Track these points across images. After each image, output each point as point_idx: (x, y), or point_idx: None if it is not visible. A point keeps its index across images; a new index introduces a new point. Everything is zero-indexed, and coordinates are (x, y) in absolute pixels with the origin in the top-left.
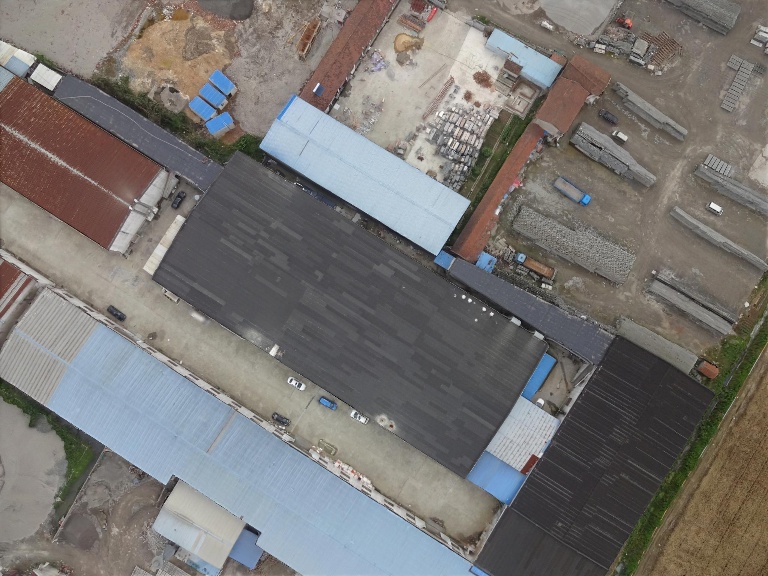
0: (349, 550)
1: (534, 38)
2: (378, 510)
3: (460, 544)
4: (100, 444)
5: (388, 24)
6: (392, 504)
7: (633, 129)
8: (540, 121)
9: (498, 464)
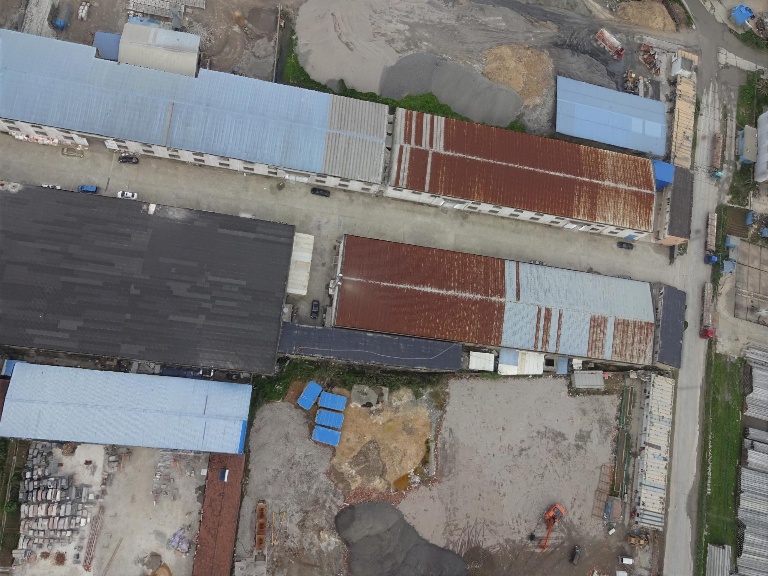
0: (1, 67)
1: None
2: None
3: None
4: None
5: None
6: None
7: None
8: None
9: None
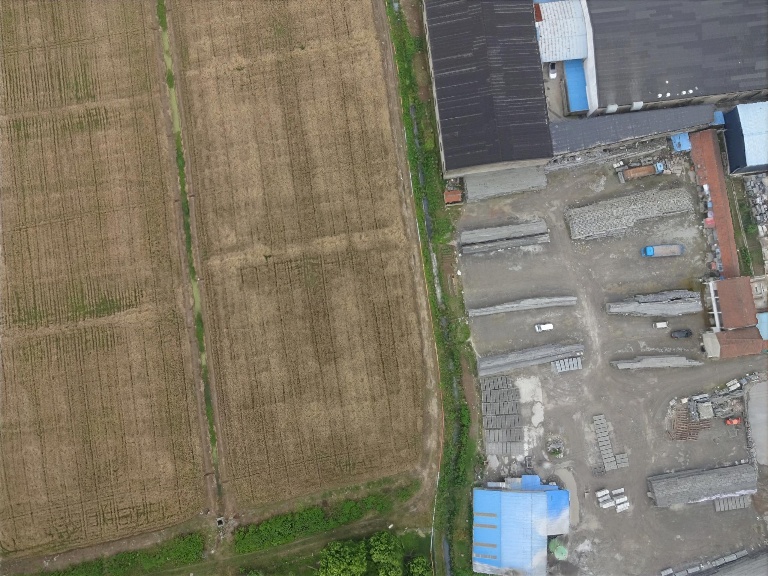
0: None
1: None
2: None
3: None
4: None
5: None
6: None
7: (655, 341)
8: None
9: None
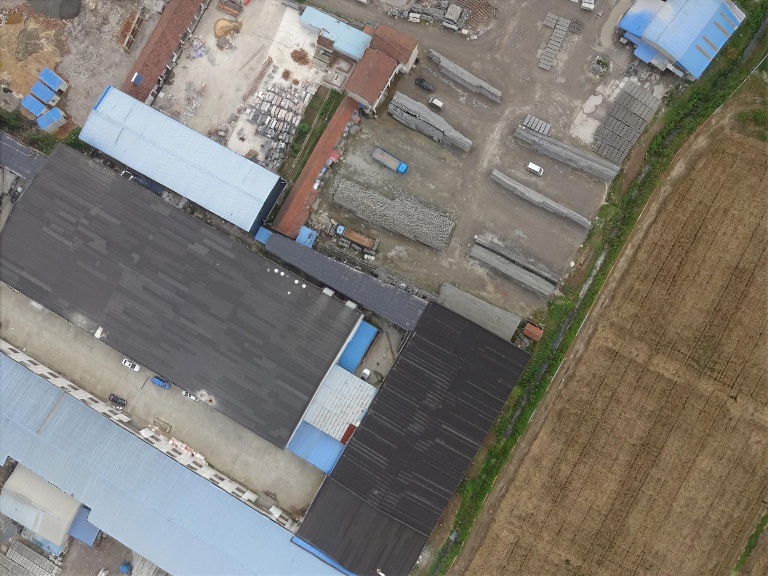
0: (172, 523)
1: (349, 13)
2: (201, 484)
3: (292, 516)
4: None
5: (208, 11)
6: (223, 478)
7: (451, 95)
8: (350, 93)
9: (318, 435)
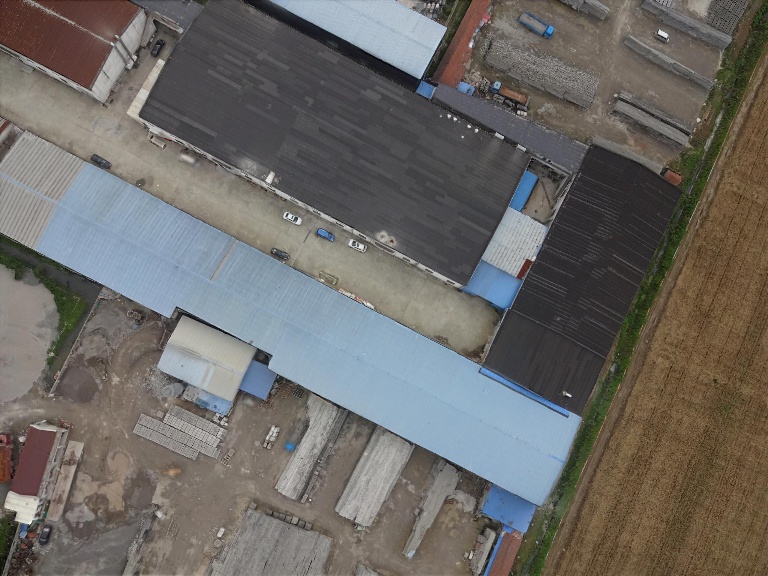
0: (362, 362)
1: None
2: (386, 323)
3: None
4: (93, 295)
5: None
6: None
7: None
8: None
9: (495, 272)
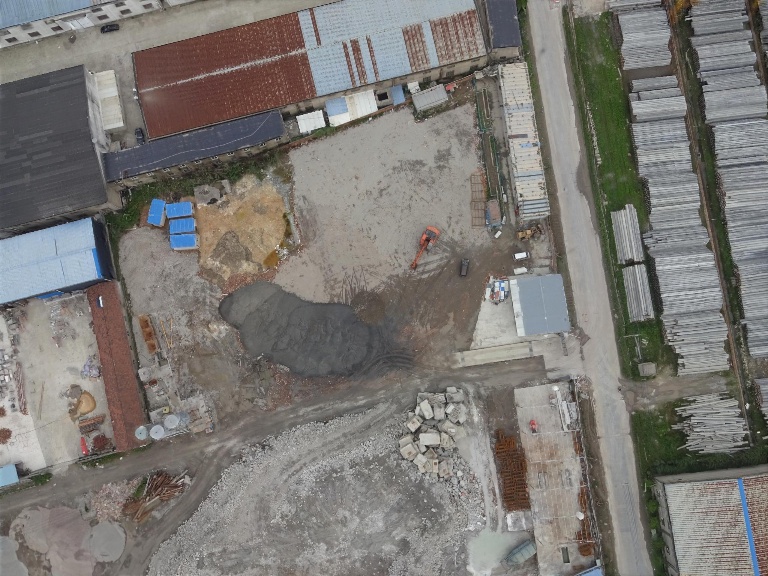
0: None
1: None
2: None
3: None
4: None
5: None
6: None
7: None
8: None
9: None
